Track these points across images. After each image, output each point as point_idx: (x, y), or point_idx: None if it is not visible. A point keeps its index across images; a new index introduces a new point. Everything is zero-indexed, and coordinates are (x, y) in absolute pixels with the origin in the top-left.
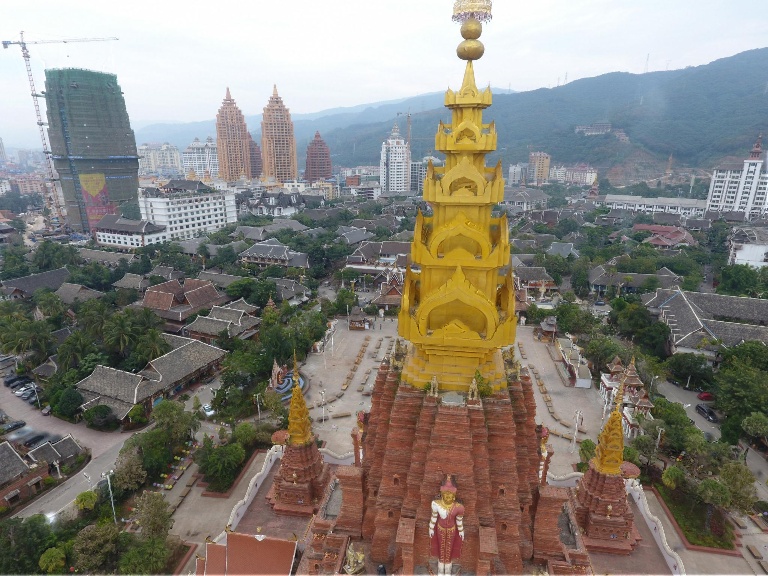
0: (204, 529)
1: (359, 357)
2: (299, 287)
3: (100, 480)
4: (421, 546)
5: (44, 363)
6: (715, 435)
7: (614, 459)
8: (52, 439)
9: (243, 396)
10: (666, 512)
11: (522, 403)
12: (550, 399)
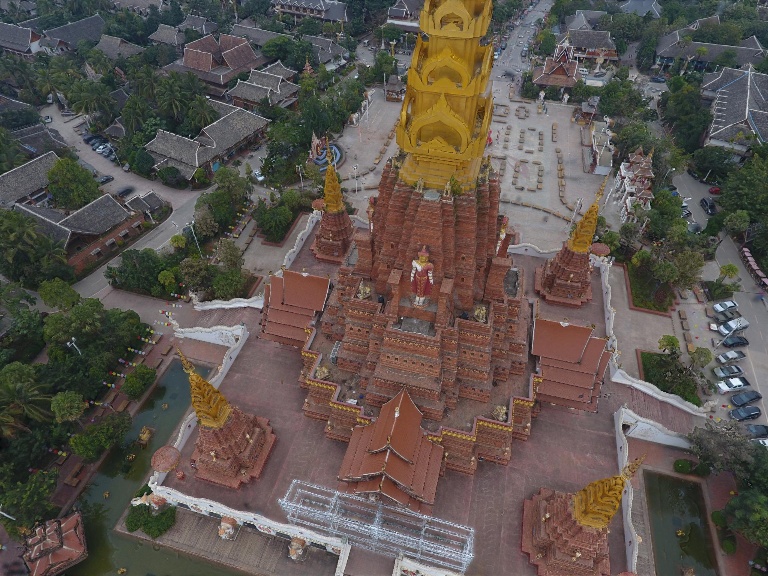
0: (266, 267)
1: (393, 132)
2: (336, 48)
3: (184, 227)
4: (406, 286)
5: (112, 124)
6: (705, 226)
7: (584, 241)
8: (138, 192)
9: (287, 165)
10: (626, 283)
11: (487, 200)
12: (564, 184)
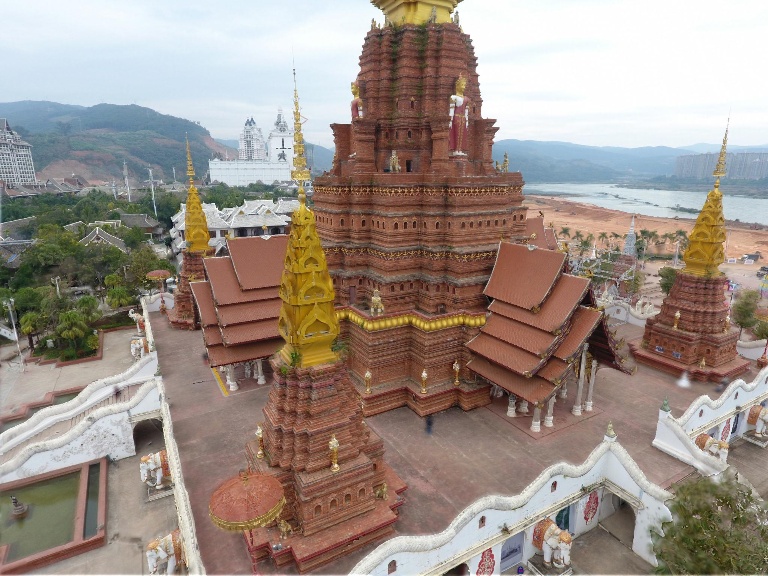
0: None
1: None
2: None
3: None
4: None
5: None
6: None
7: None
8: None
9: None
10: None
11: None
12: None
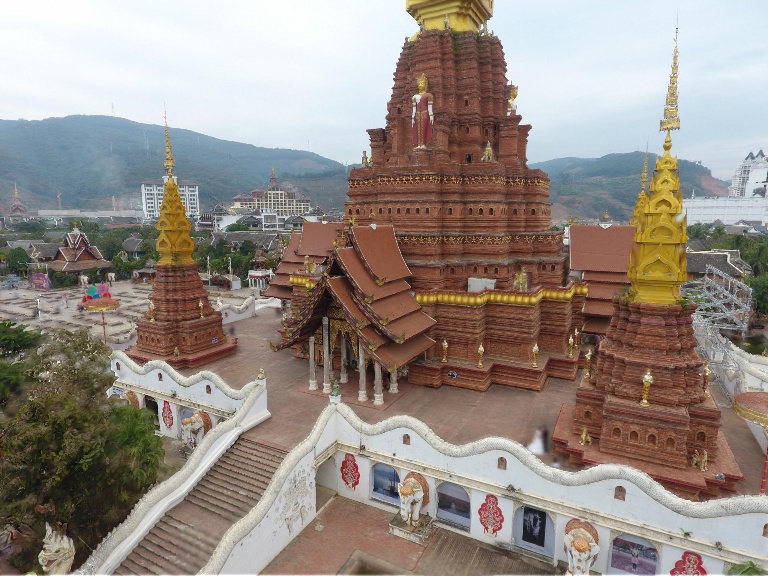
0: None
1: None
2: None
3: None
4: None
5: None
6: None
7: None
8: None
9: None
10: None
11: None
12: (232, 294)
